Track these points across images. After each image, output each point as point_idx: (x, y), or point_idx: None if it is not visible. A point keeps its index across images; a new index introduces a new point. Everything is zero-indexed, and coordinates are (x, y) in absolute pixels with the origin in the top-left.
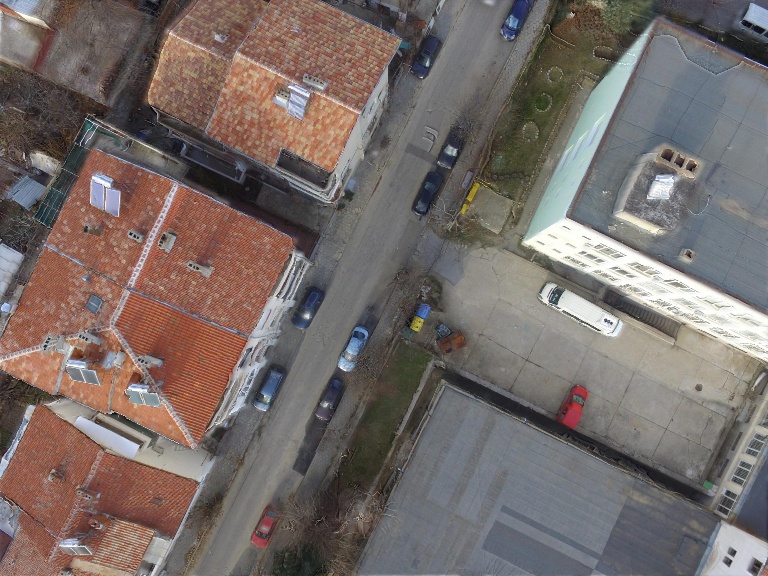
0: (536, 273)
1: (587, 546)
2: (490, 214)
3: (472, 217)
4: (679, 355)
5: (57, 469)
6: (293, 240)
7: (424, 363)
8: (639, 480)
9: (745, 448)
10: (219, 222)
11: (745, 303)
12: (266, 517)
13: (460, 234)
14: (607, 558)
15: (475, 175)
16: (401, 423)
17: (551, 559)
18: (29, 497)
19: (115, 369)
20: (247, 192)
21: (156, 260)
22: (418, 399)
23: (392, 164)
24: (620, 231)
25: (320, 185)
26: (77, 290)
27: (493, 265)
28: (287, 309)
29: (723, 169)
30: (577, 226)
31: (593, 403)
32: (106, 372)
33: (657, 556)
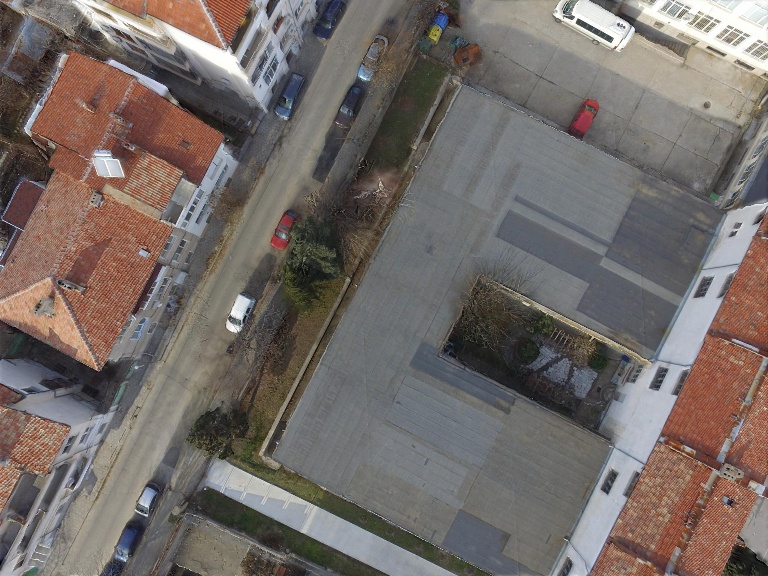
0: None
1: (597, 234)
2: None
3: None
4: (688, 74)
5: (91, 103)
6: None
7: (441, 77)
8: (649, 174)
9: (751, 155)
10: None
11: None
12: (286, 216)
13: None
14: (617, 246)
15: None
16: (418, 135)
17: (562, 247)
18: (63, 132)
19: None
20: None
21: None
22: (435, 112)
23: None
24: None
25: None
26: None
27: None
28: (310, 19)
29: None
30: None
31: (604, 119)
32: None
33: (665, 245)
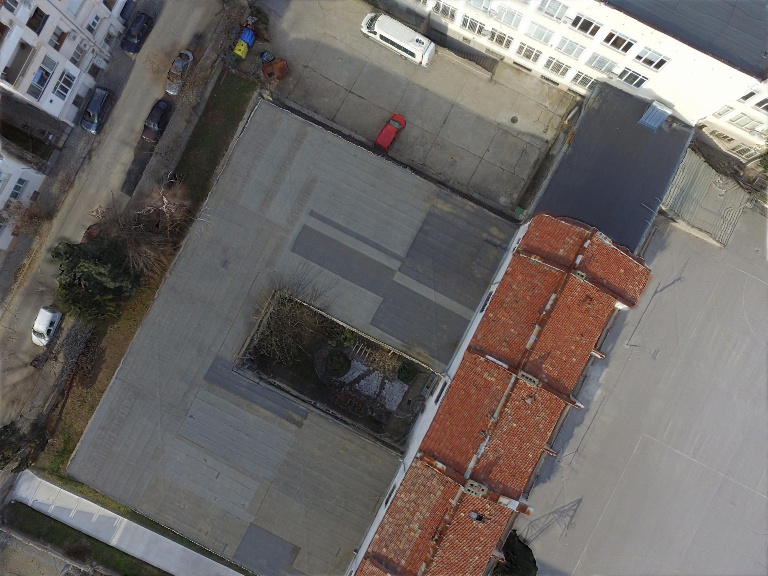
0: (361, 8)
1: (391, 249)
2: None
3: None
4: (496, 89)
5: None
6: None
7: (250, 92)
8: (444, 190)
9: None
10: None
11: None
12: None
13: None
14: (410, 260)
15: None
16: (227, 149)
17: (357, 262)
18: None
19: None
20: None
21: None
22: (244, 126)
23: None
24: None
25: None
26: None
27: None
28: (116, 33)
29: None
30: None
31: (413, 133)
32: None
33: (458, 259)
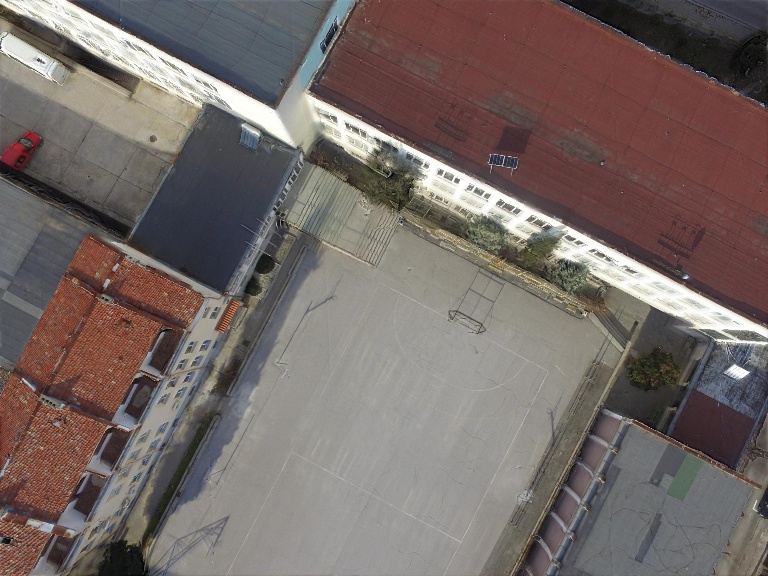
0: (1, 27)
1: (1, 268)
2: None
3: None
4: (136, 108)
5: None
6: None
7: None
8: (58, 209)
9: None
10: None
11: None
12: None
13: None
14: (18, 280)
15: None
16: None
17: None
18: None
19: None
20: None
21: None
22: None
23: None
24: None
25: None
26: None
27: None
28: None
29: None
30: None
31: (51, 151)
32: None
33: None
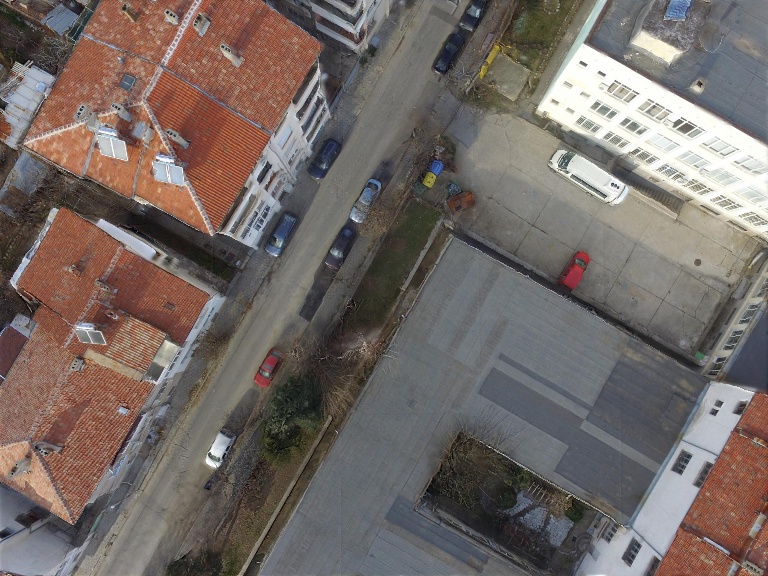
0: (548, 142)
1: (579, 397)
2: (507, 82)
3: (489, 83)
4: (681, 230)
5: (77, 265)
6: None
7: (433, 221)
8: (634, 338)
9: (738, 319)
10: (252, 14)
11: (750, 136)
12: (271, 356)
13: (477, 99)
14: (598, 410)
15: (496, 37)
16: (407, 278)
17: (544, 408)
18: (48, 291)
19: (143, 148)
20: None
21: (190, 42)
22: (425, 256)
23: (415, 25)
24: (635, 61)
25: (349, 4)
26: (111, 71)
27: (506, 131)
28: (304, 158)
29: (738, 10)
30: (594, 55)
31: (594, 271)
32: (135, 148)
33: (646, 411)
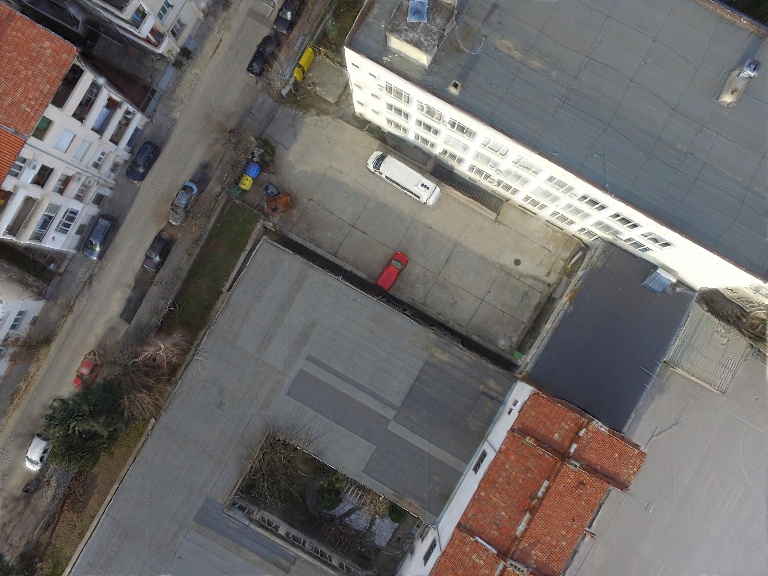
0: (367, 143)
1: (387, 398)
2: (327, 84)
3: (309, 85)
4: (500, 230)
5: None
6: (119, 84)
7: (253, 223)
8: (442, 339)
9: (552, 319)
10: None
11: (507, 136)
12: (87, 359)
13: (296, 101)
14: (405, 410)
15: (307, 39)
16: (228, 280)
17: (352, 408)
18: None
19: None
20: (88, 44)
21: None
22: (245, 257)
23: (232, 28)
24: (394, 62)
25: (118, 8)
26: None
27: (326, 133)
28: (121, 161)
29: (499, 11)
30: (356, 57)
31: (414, 271)
32: None
33: (453, 411)
